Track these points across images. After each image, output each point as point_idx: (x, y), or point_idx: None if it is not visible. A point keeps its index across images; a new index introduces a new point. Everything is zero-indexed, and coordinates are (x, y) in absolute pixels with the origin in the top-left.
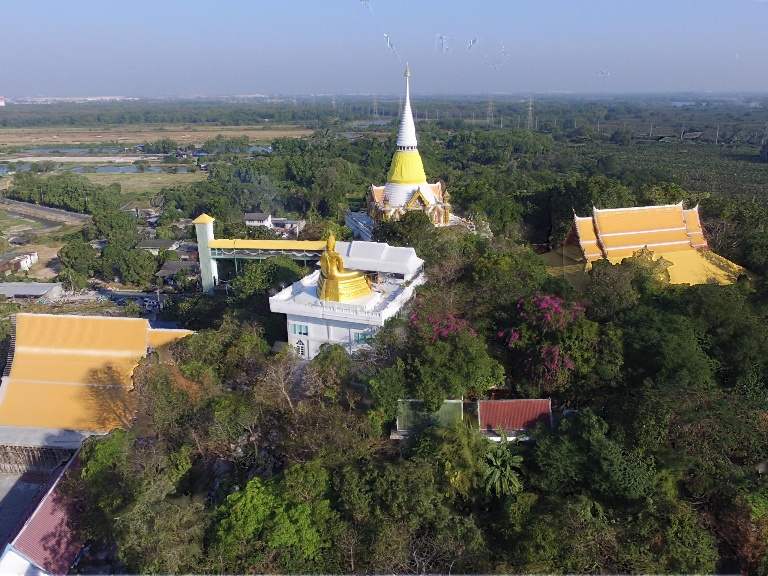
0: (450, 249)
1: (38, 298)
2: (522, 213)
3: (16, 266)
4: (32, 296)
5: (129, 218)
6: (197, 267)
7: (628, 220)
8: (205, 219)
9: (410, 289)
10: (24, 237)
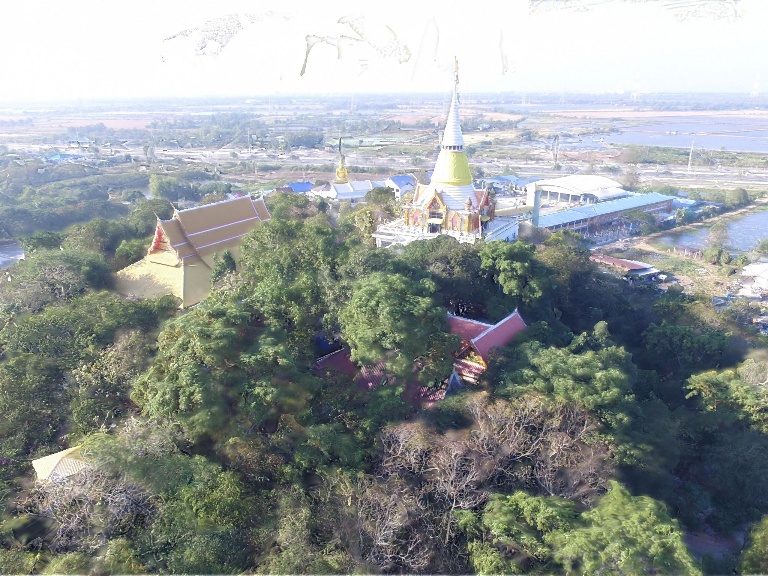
0: None
1: None
2: None
3: None
4: None
5: None
6: None
7: None
8: None
9: None
10: None
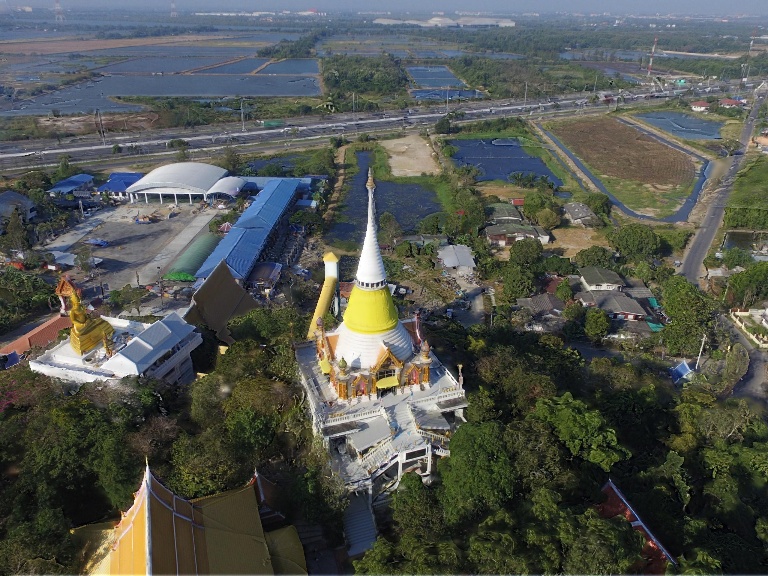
0: None
1: (454, 269)
2: (477, 498)
3: (511, 240)
4: (445, 265)
5: (645, 240)
6: (543, 313)
7: None
8: (326, 256)
9: (92, 377)
10: (591, 220)
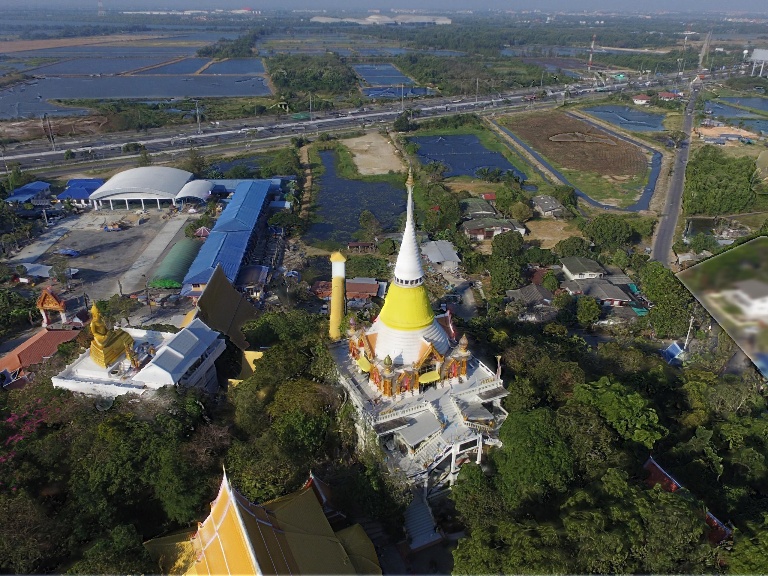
0: (236, 401)
1: (439, 264)
2: None
3: (489, 234)
4: None
5: (618, 229)
6: (534, 303)
7: (242, 560)
8: (334, 257)
9: (123, 390)
10: None
